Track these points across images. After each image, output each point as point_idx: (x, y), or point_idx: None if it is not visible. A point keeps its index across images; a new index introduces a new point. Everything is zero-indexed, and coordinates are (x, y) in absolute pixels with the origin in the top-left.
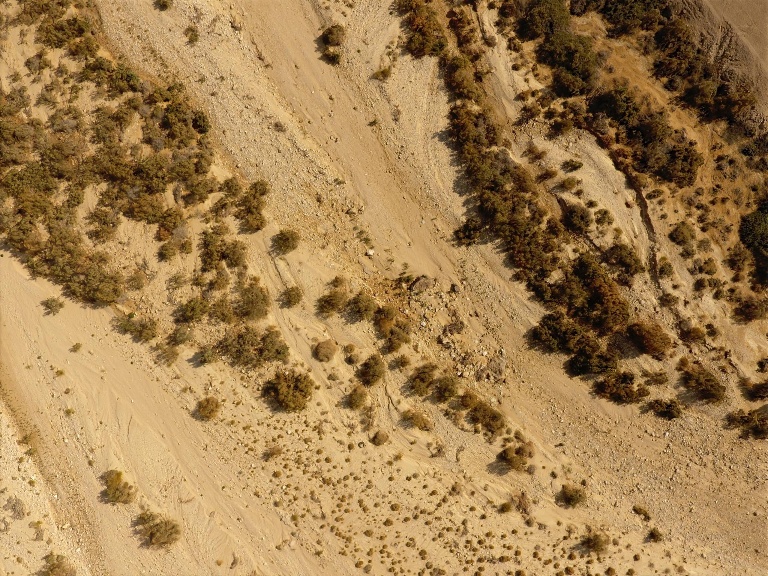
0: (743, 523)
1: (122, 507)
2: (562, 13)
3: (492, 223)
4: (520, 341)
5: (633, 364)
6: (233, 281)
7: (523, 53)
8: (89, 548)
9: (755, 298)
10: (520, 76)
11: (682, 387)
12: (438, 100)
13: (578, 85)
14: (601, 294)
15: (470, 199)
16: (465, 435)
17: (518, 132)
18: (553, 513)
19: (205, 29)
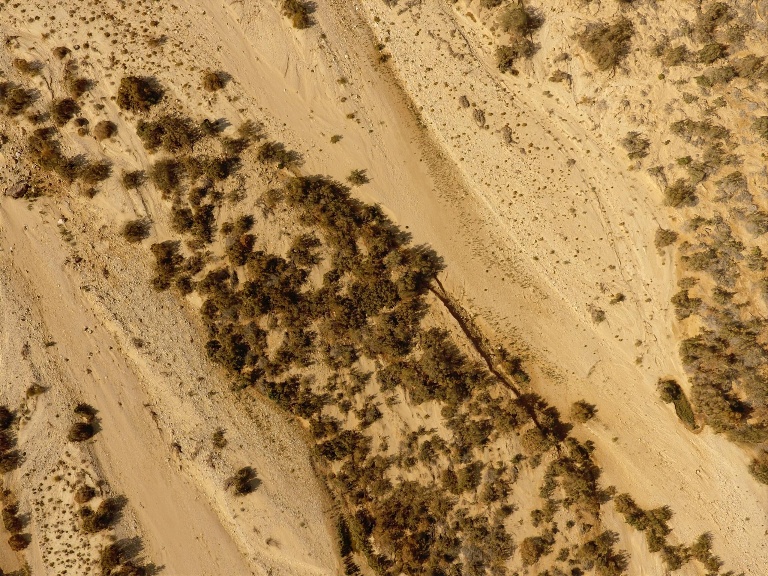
0: None
1: None
2: None
3: None
4: None
5: None
6: (186, 196)
7: None
8: None
9: None
10: None
11: None
12: None
13: None
14: None
15: None
16: None
17: None
18: None
19: (206, 445)
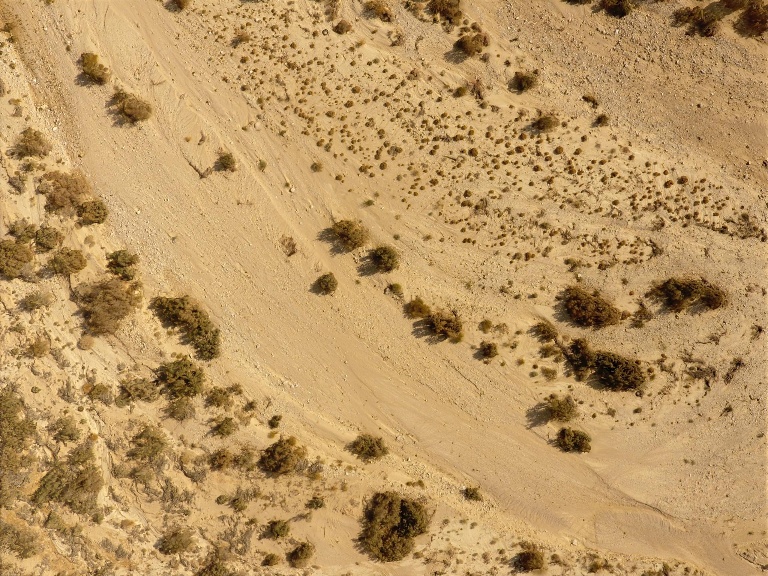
0: (687, 113)
1: (97, 89)
2: None
3: None
4: None
5: None
6: None
7: None
8: (65, 128)
9: None
10: None
11: None
12: None
13: None
14: None
15: None
16: (424, 25)
17: None
18: (506, 98)
19: None
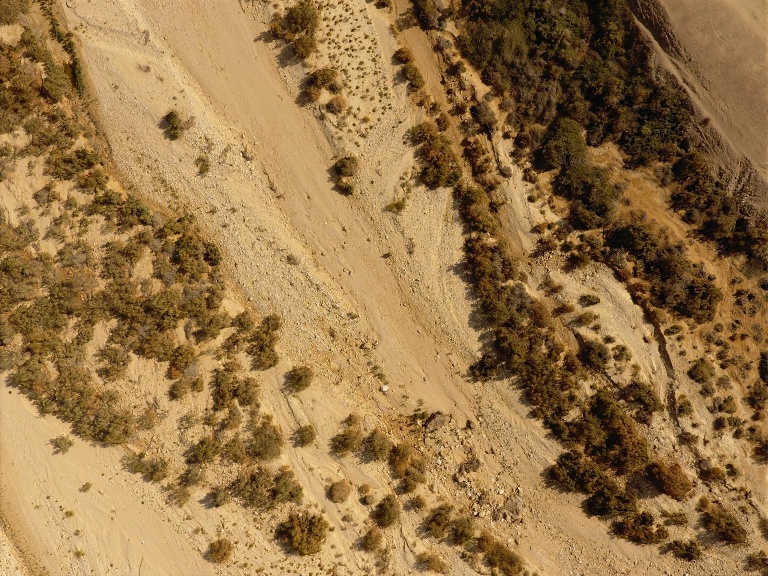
0: None
1: None
2: (579, 146)
3: (508, 361)
4: (537, 479)
5: (652, 504)
6: (245, 419)
7: (539, 185)
8: None
9: None
10: (536, 208)
11: (702, 528)
12: (453, 232)
13: (595, 222)
14: (620, 436)
15: (486, 334)
16: None
17: (534, 264)
18: None
19: (216, 159)
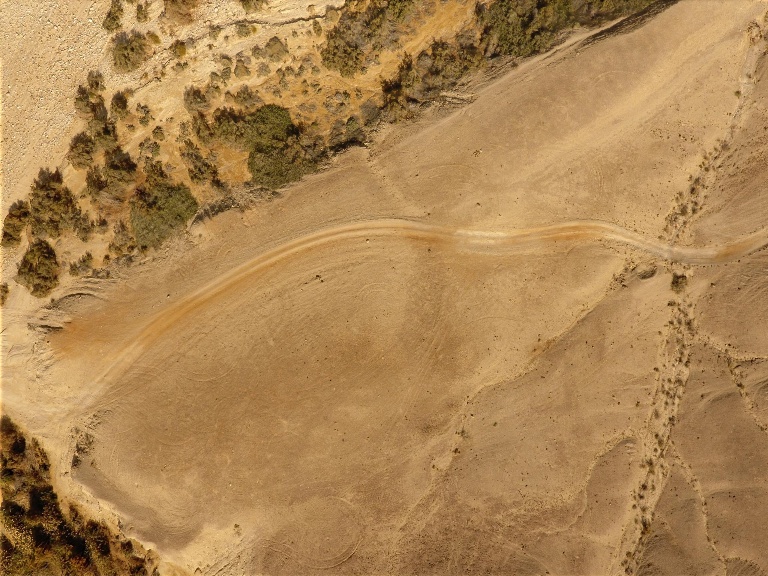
0: (1, 81)
1: None
2: None
3: None
4: None
5: None
6: None
7: None
8: None
9: (208, 111)
10: None
11: None
12: None
13: None
14: None
15: None
16: None
17: None
18: None
19: None
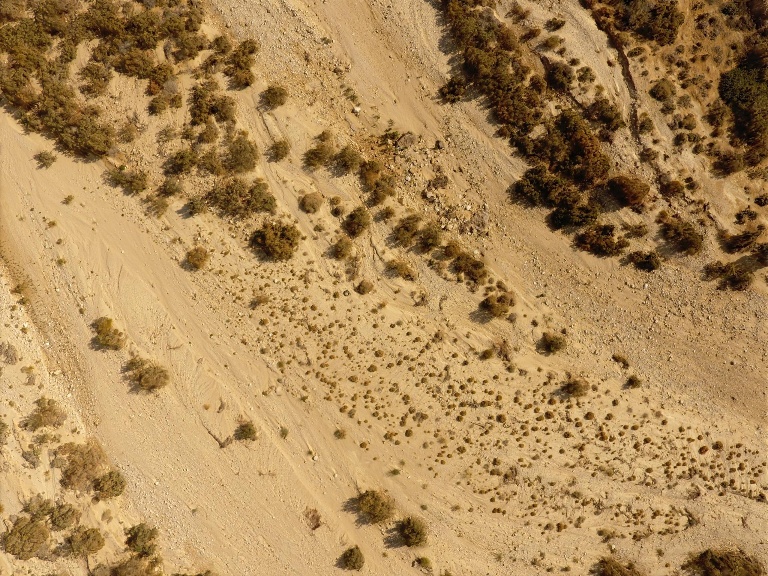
0: (720, 372)
1: (112, 354)
2: None
3: (476, 78)
4: (503, 196)
5: (613, 217)
6: (222, 135)
7: None
8: (80, 394)
9: None
10: None
11: (661, 239)
12: None
13: None
14: (582, 145)
15: (455, 57)
16: (448, 284)
17: None
18: (534, 360)
19: None
